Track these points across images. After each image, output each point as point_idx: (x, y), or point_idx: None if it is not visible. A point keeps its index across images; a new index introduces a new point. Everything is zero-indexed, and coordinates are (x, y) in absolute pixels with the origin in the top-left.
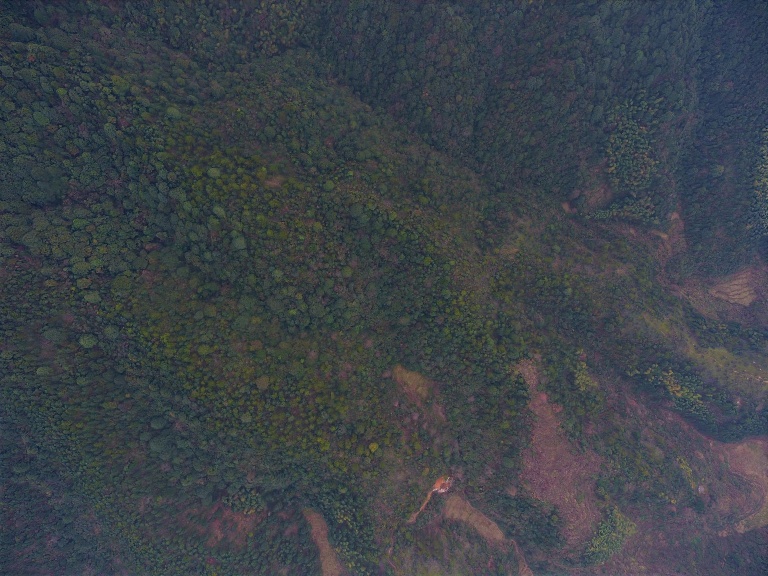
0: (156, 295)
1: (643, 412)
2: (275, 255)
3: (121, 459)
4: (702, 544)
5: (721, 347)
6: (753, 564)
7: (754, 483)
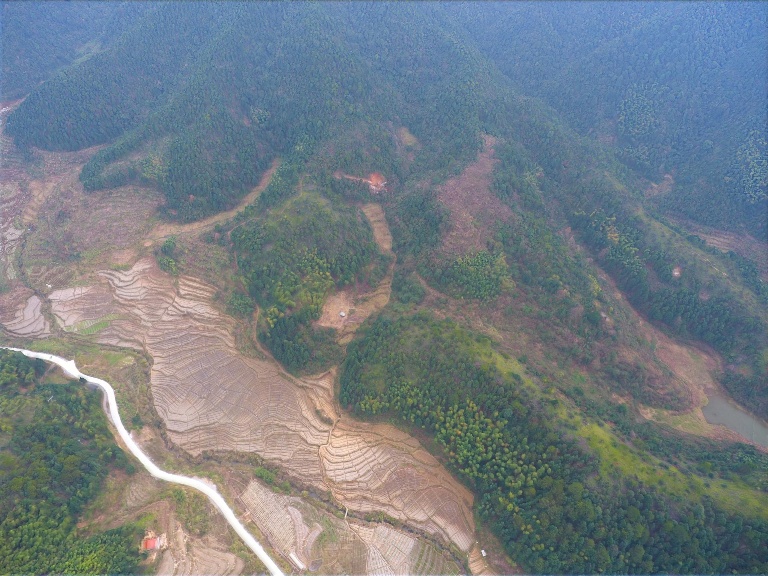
0: (329, 6)
1: (576, 245)
2: (393, 23)
3: (243, 40)
4: (585, 383)
5: (674, 231)
6: (642, 426)
7: (682, 382)
